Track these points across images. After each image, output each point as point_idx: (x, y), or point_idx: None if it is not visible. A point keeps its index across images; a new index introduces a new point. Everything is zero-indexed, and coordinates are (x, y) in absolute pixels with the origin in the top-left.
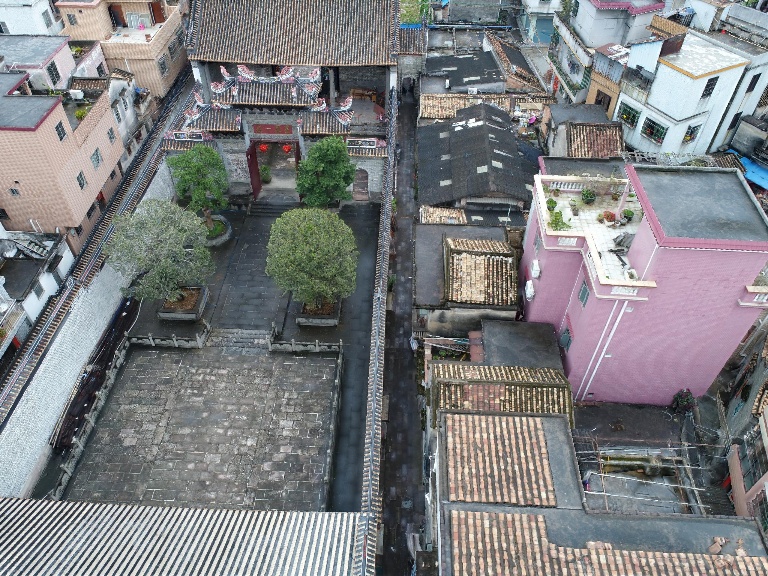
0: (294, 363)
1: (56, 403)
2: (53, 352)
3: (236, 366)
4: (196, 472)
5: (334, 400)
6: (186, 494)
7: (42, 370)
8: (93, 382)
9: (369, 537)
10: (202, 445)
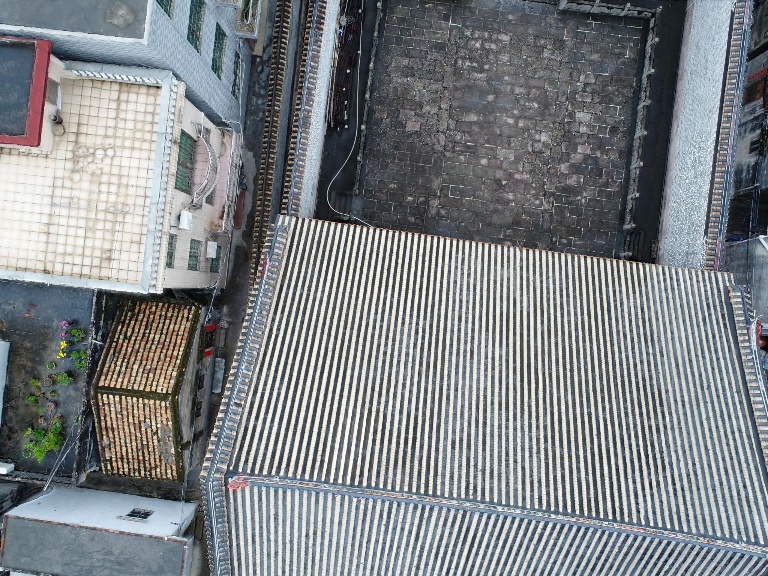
0: (590, 31)
1: (326, 75)
2: (326, 17)
3: (519, 30)
4: (490, 169)
5: (646, 95)
6: (483, 193)
7: (322, 45)
8: (351, 41)
9: (748, 313)
10: (492, 137)
